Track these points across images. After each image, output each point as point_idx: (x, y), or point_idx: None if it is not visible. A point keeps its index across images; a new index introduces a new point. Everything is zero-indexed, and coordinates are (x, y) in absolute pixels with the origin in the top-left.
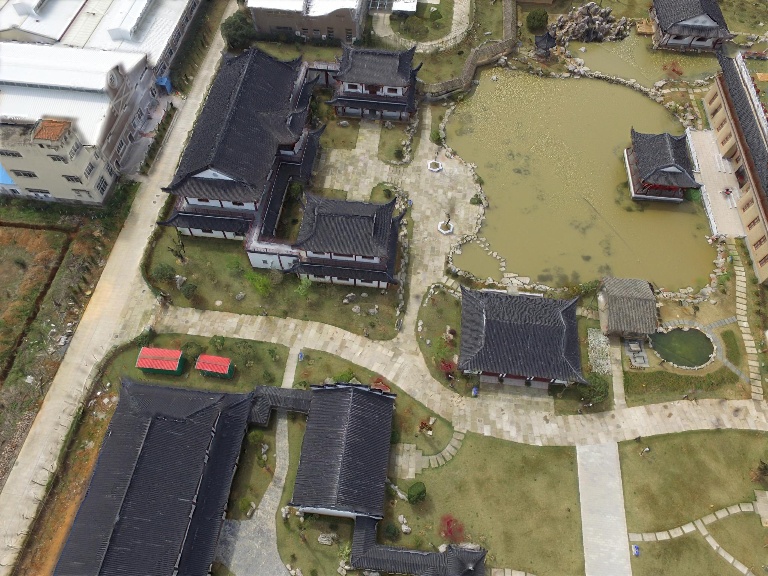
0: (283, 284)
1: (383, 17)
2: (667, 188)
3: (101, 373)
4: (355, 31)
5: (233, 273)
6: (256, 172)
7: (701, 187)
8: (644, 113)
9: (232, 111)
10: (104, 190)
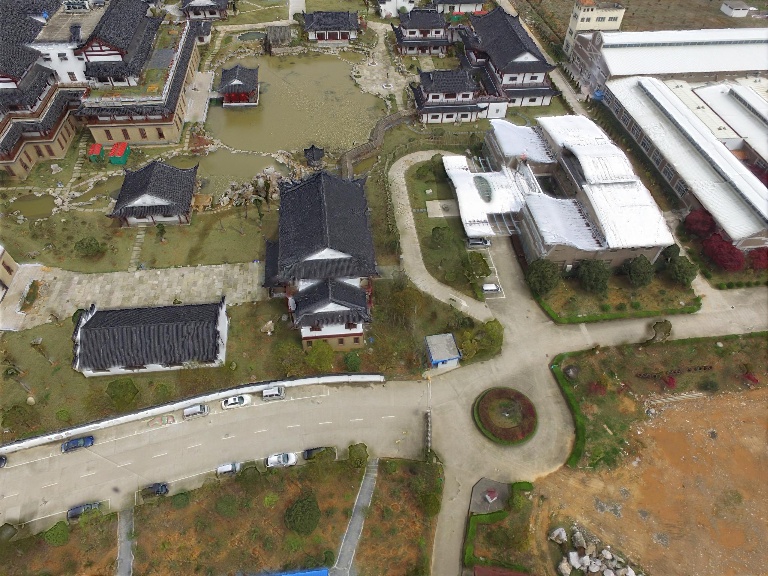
0: None
1: None
2: None
3: None
4: None
5: None
6: None
7: None
8: None
9: None
10: None
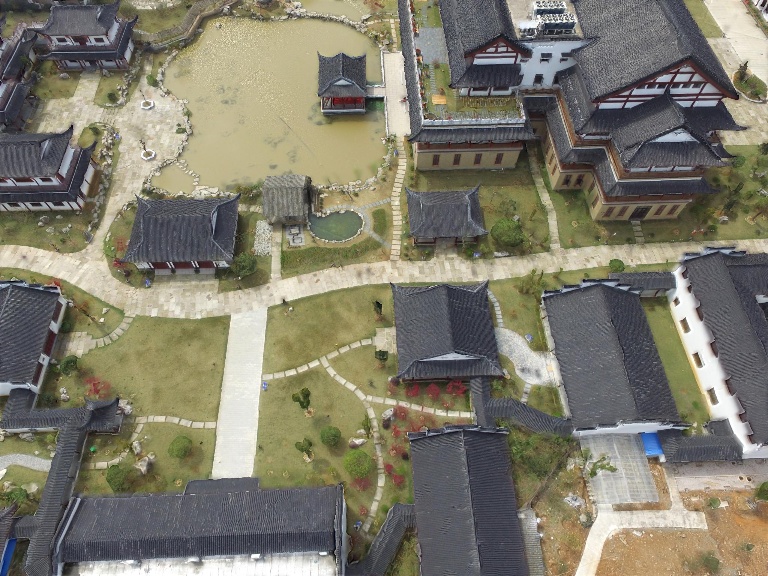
0: None
1: None
2: (352, 102)
3: None
4: None
5: None
6: None
7: (384, 99)
8: (354, 44)
9: None
10: None
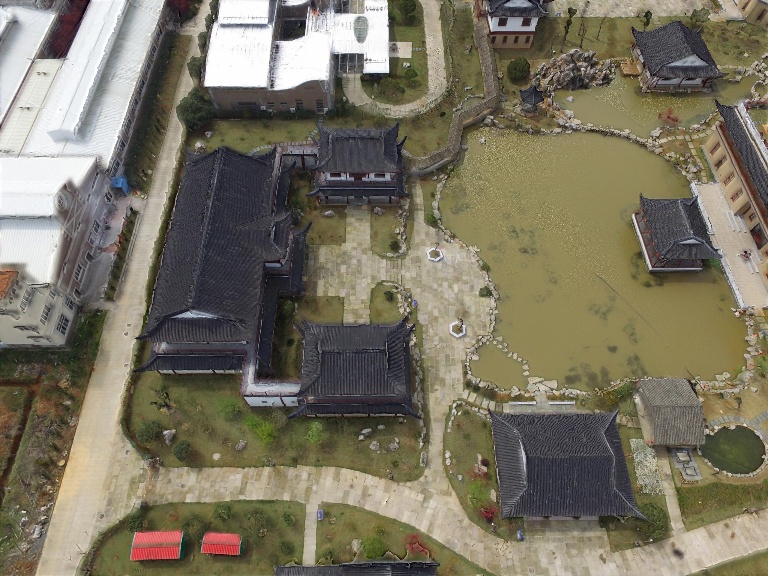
0: (288, 424)
1: (353, 78)
2: None
3: (89, 571)
4: (326, 101)
5: (228, 416)
6: (243, 302)
7: (718, 251)
8: (643, 166)
9: (207, 232)
10: (65, 328)
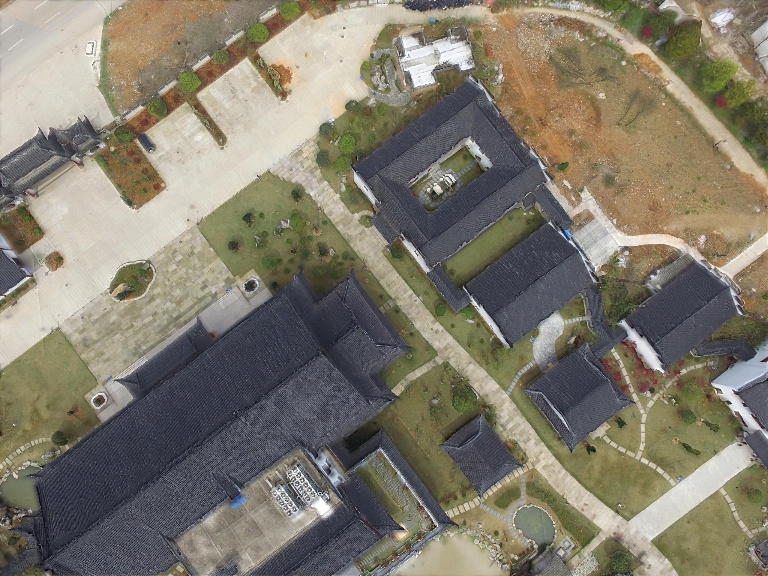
0: None
1: None
2: None
3: None
4: None
5: None
6: None
7: None
8: None
9: None
10: None
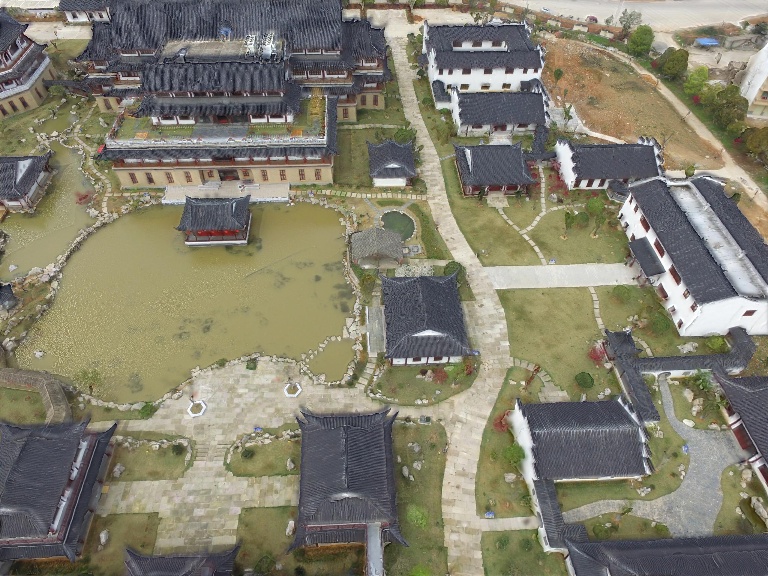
0: None
1: None
2: None
3: None
4: None
5: None
6: None
7: None
8: (126, 231)
9: None
10: None
